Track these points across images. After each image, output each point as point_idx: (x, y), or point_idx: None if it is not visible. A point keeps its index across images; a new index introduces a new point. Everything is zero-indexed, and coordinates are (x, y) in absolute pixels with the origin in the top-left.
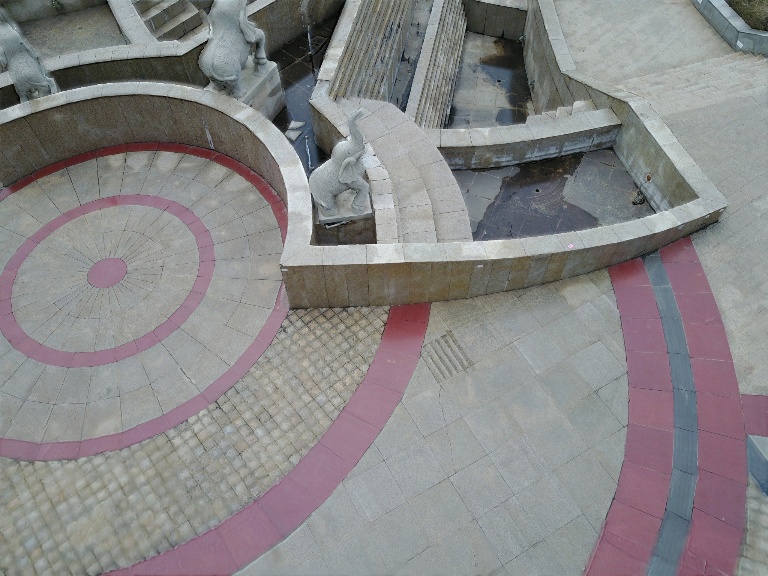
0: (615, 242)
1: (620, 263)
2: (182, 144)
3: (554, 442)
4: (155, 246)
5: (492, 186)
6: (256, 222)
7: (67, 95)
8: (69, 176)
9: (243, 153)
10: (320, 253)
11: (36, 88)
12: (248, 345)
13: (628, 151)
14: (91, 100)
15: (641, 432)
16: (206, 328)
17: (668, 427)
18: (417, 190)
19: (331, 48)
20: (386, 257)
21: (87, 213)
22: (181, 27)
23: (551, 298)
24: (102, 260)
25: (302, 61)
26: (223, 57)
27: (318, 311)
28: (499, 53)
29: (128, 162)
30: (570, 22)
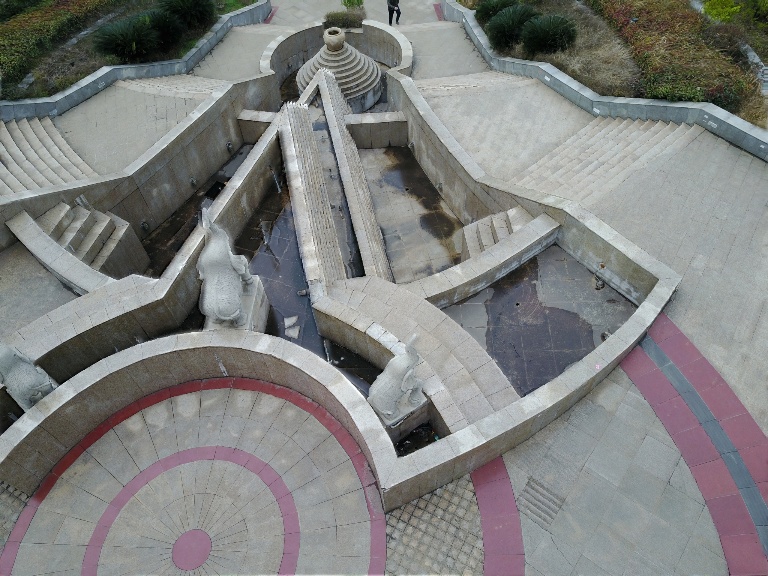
0: (626, 348)
1: (626, 357)
2: (193, 381)
3: (662, 544)
4: (225, 501)
5: (479, 314)
6: (308, 437)
7: (73, 384)
8: (94, 459)
9: (264, 373)
10: (411, 462)
11: (39, 390)
12: (367, 567)
13: (574, 246)
14: (100, 380)
15: (718, 505)
16: (320, 567)
17: (734, 491)
18: (446, 358)
19: (302, 244)
20: (469, 443)
21: (136, 492)
22: (99, 239)
23: (592, 411)
24: (179, 538)
25: (260, 252)
26: (226, 299)
27: (411, 505)
28: (394, 162)
29: (148, 420)
30: (454, 127)
